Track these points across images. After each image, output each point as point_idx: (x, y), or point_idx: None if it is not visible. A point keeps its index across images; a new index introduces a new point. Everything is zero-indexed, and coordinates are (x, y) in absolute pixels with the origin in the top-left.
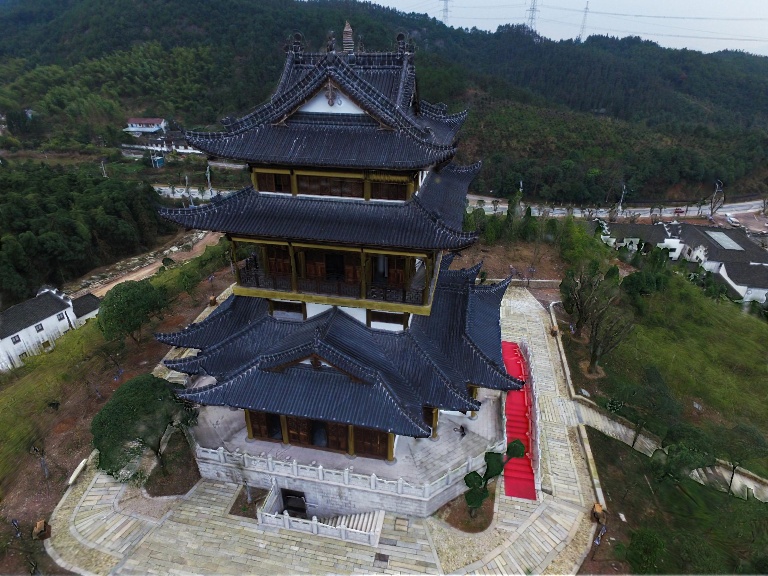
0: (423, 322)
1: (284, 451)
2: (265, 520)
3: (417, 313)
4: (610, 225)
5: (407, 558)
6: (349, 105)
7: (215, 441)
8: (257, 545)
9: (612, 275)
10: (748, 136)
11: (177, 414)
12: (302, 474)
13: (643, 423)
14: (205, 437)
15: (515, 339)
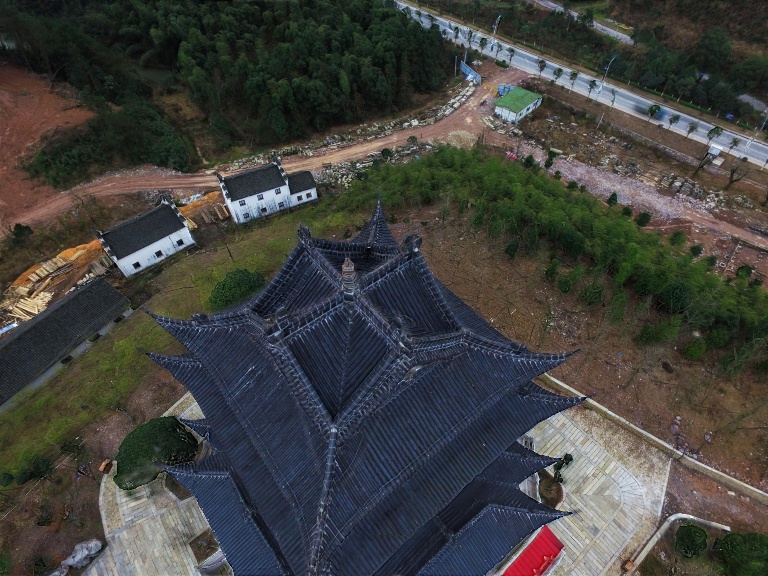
0: None
1: None
2: None
3: None
4: None
5: None
6: None
7: None
8: None
9: None
10: None
11: None
12: None
13: None
14: None
15: (568, 538)
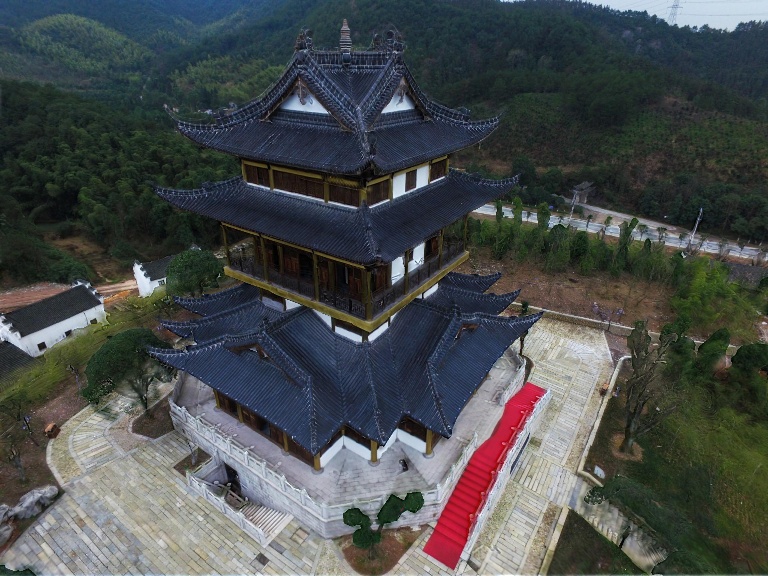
0: (396, 339)
1: (236, 428)
2: (193, 484)
3: (360, 327)
4: None
5: (283, 570)
6: (318, 104)
7: (192, 401)
8: (175, 503)
9: (717, 340)
10: None
11: (153, 368)
12: (235, 454)
13: (628, 532)
14: (188, 395)
15: (549, 386)
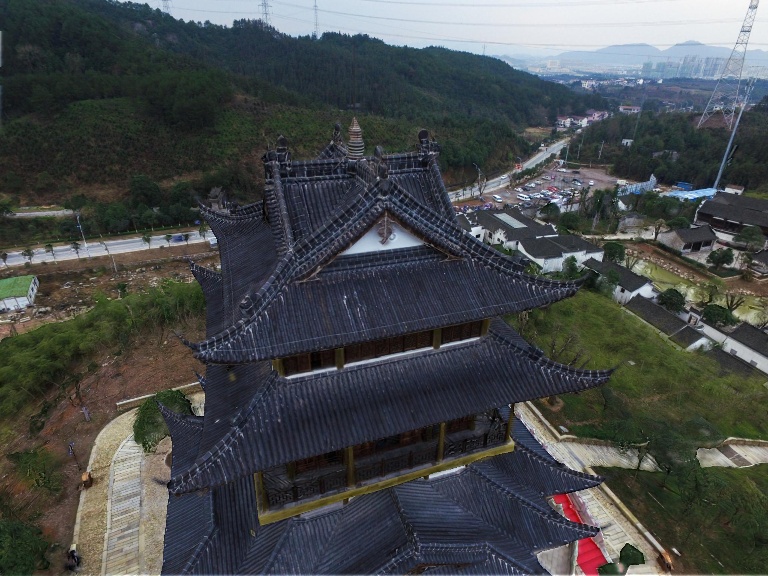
0: None
1: None
2: None
3: None
4: None
5: None
6: (405, 238)
7: None
8: None
9: None
10: (482, 124)
11: None
12: None
13: None
14: None
15: None
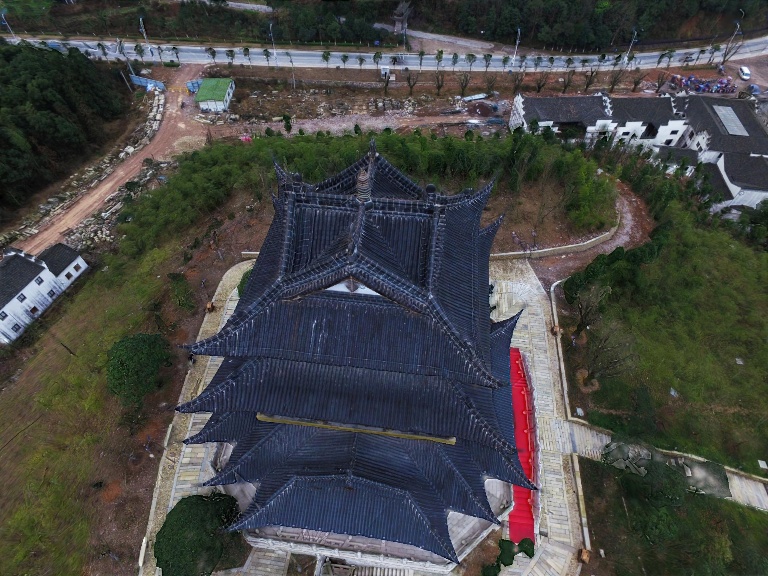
0: None
1: None
2: None
3: (442, 442)
4: (614, 101)
5: None
6: (374, 291)
7: None
8: None
9: (616, 257)
10: None
11: None
12: (343, 553)
13: None
14: None
15: (517, 343)
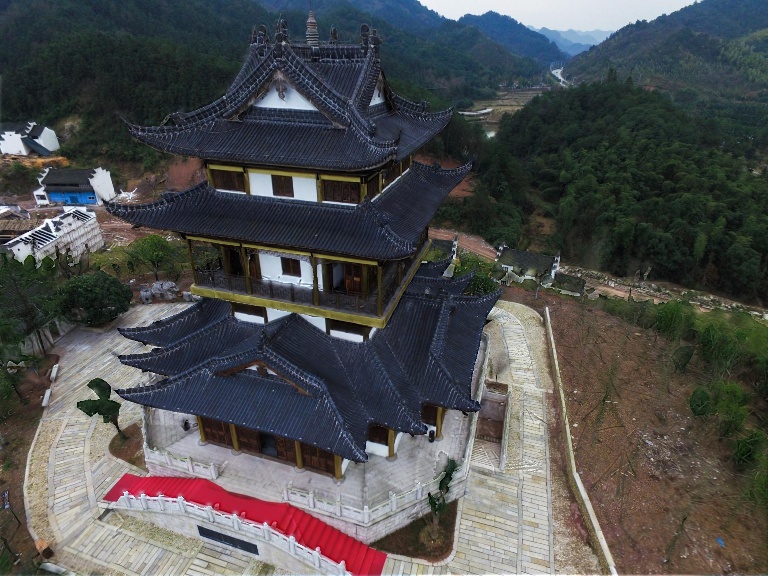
0: (256, 336)
1: None
2: None
3: None
4: None
5: None
6: None
7: None
8: None
9: None
10: None
11: None
12: None
13: None
14: None
15: None
